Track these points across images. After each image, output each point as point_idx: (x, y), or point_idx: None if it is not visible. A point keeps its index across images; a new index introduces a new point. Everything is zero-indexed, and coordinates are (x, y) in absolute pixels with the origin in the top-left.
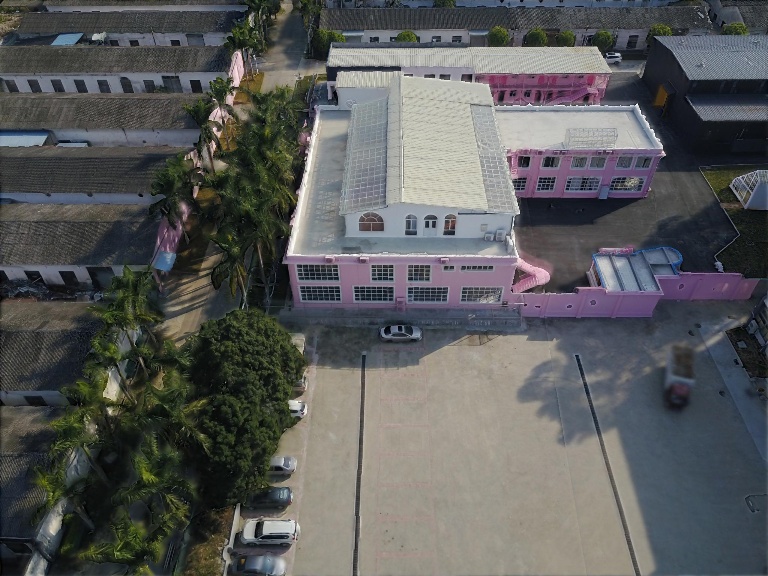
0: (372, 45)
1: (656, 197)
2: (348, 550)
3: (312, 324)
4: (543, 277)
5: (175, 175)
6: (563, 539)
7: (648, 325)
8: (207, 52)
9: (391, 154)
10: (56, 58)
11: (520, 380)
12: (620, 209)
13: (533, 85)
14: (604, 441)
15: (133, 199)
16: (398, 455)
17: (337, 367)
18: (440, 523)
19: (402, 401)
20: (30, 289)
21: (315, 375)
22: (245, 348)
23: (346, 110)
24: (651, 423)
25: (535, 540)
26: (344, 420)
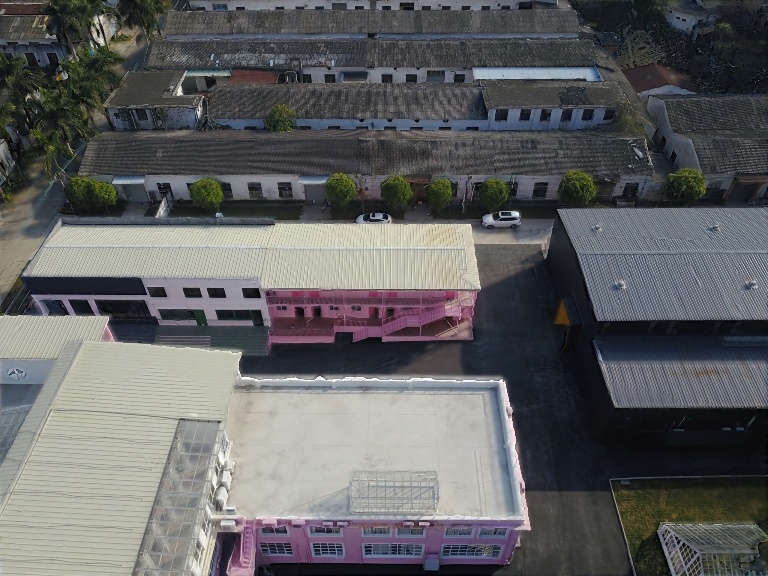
0: (124, 221)
1: (526, 565)
2: None
3: None
4: None
5: None
6: None
7: None
8: None
9: None
10: None
11: None
12: None
13: (362, 298)
14: None
15: None
16: None
17: None
18: None
19: None
20: None
21: None
22: None
23: (9, 384)
24: None
25: None
26: None
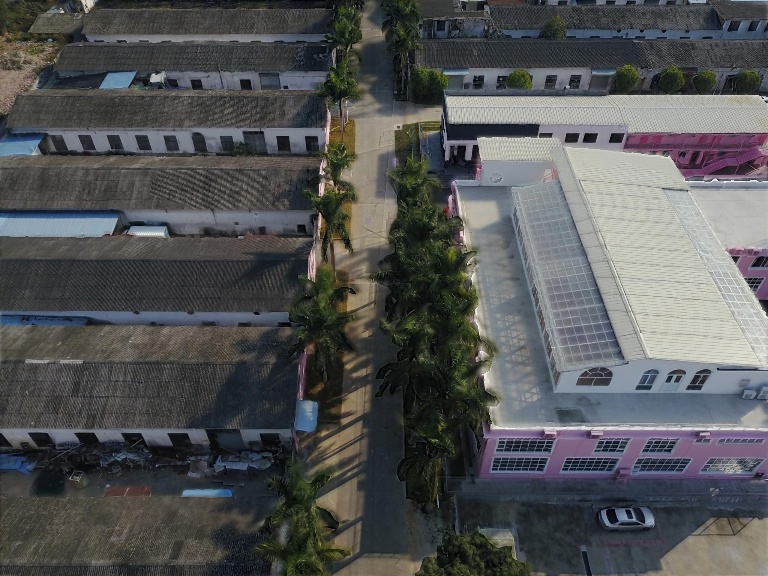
0: (492, 92)
1: None
2: None
3: (504, 501)
4: None
5: (322, 305)
6: None
7: None
8: (296, 101)
9: (599, 273)
10: (113, 109)
11: None
12: None
13: (692, 144)
14: None
15: (246, 317)
16: None
17: (554, 573)
18: None
19: None
20: (129, 456)
21: None
22: None
23: (489, 186)
24: None
25: None
26: None
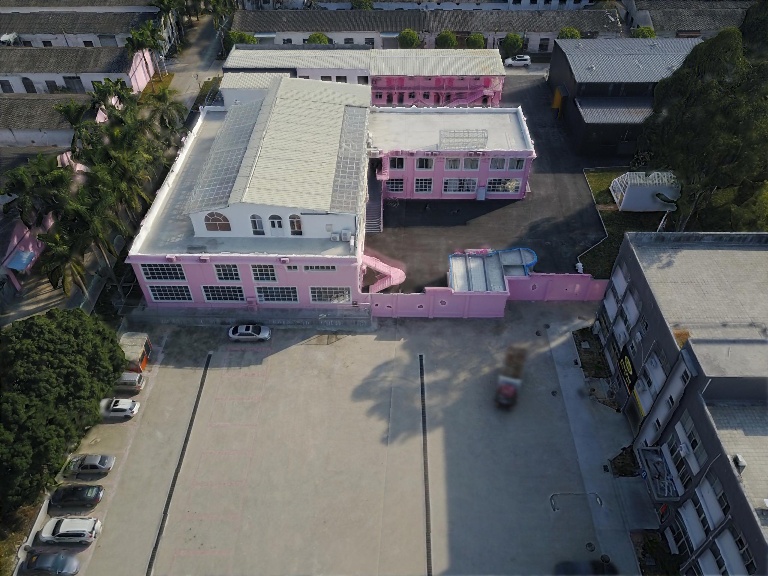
0: (275, 47)
1: (534, 198)
2: (148, 548)
3: (164, 323)
4: (398, 277)
5: (29, 174)
6: (363, 537)
7: (498, 325)
8: (109, 53)
9: (248, 154)
10: None
11: (358, 380)
12: (496, 210)
13: (430, 87)
14: (427, 440)
15: (3, 199)
16: (220, 454)
17: (180, 366)
18: (245, 521)
19: (236, 400)
20: None
21: (156, 374)
22: (45, 346)
23: None
24: (478, 422)
25: (335, 538)
26: (175, 419)
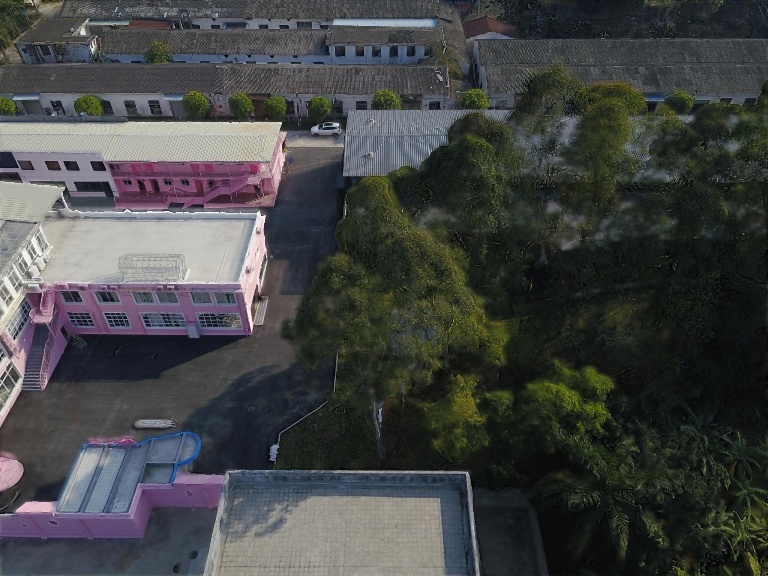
0: (10, 119)
1: (263, 335)
2: None
3: None
4: (7, 479)
5: None
6: None
7: (130, 552)
8: None
9: None
10: None
11: None
12: (208, 353)
13: (186, 173)
14: None
15: None
16: None
17: None
18: None
19: None
20: None
21: None
22: None
23: None
24: None
25: None
26: None
